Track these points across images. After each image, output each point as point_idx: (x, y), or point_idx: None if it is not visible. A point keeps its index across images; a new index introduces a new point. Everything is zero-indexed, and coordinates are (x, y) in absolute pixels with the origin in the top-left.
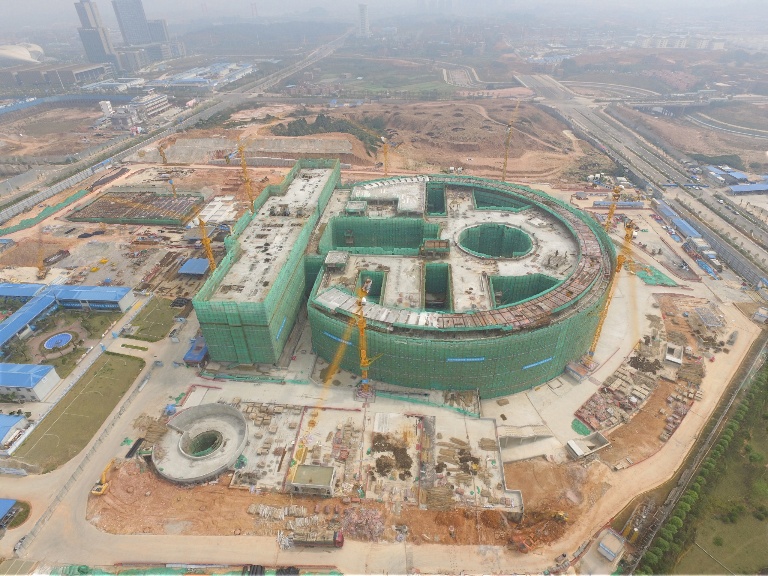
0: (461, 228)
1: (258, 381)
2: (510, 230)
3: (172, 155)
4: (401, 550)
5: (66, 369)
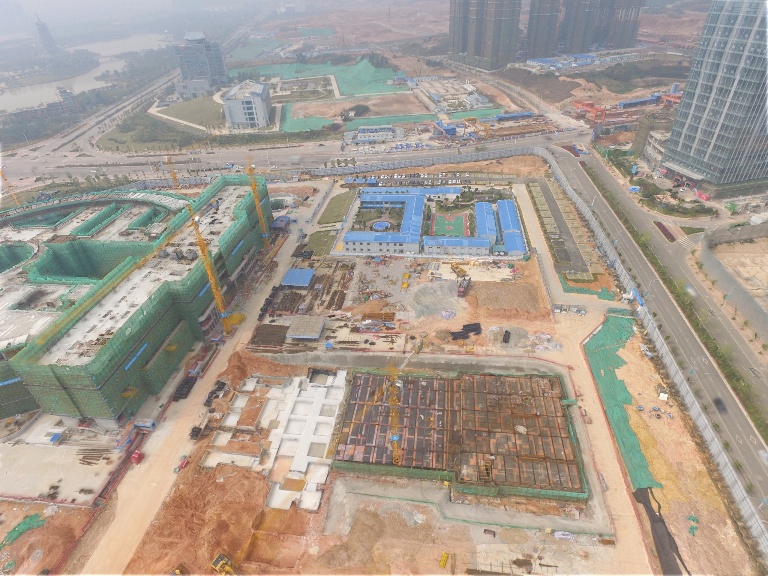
0: None
1: None
2: None
3: None
4: None
5: None
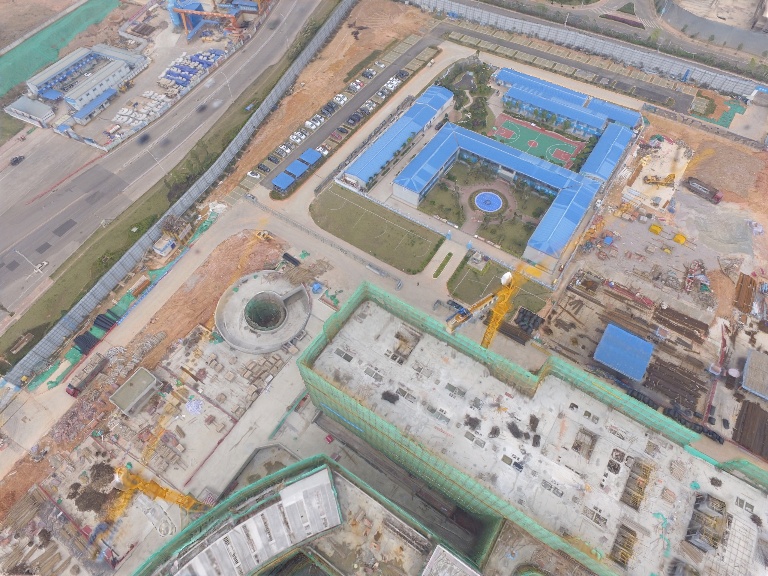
0: None
1: None
2: None
3: None
4: (27, 444)
5: (431, 209)
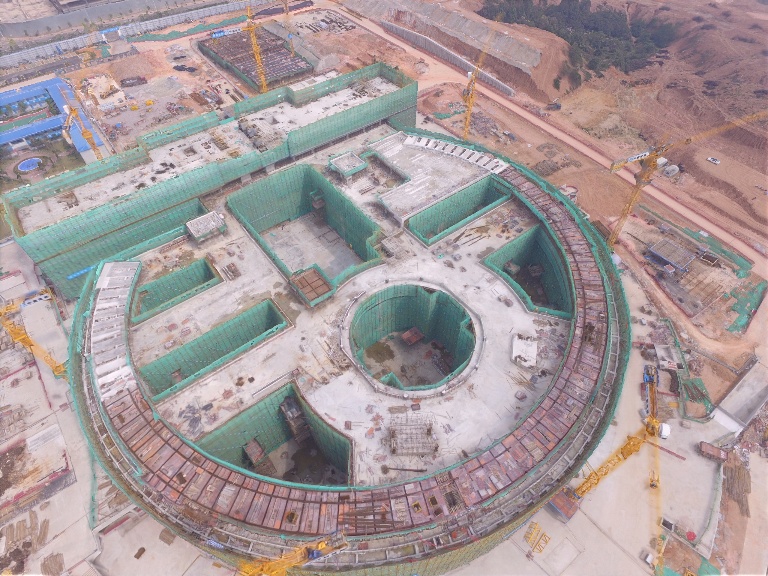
0: (409, 278)
1: (53, 304)
2: (466, 332)
3: (359, 0)
4: None
5: None
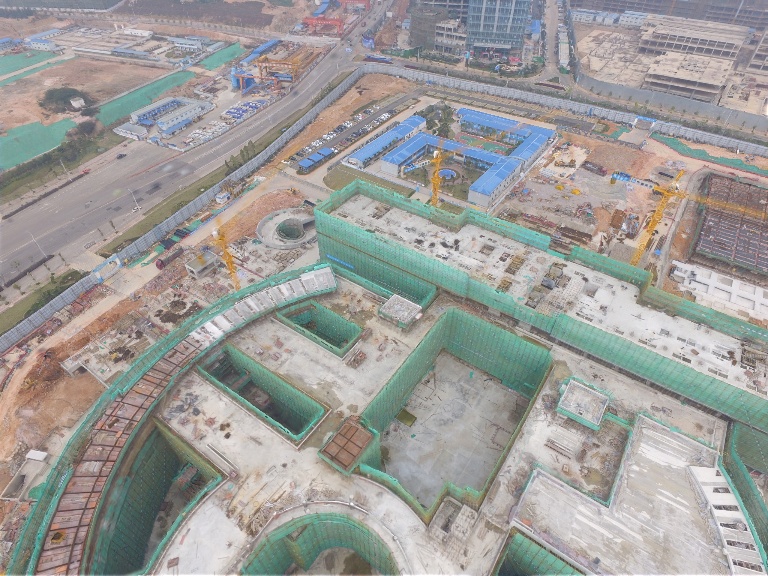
0: (411, 571)
1: None
2: None
3: None
4: (127, 293)
5: (407, 177)
